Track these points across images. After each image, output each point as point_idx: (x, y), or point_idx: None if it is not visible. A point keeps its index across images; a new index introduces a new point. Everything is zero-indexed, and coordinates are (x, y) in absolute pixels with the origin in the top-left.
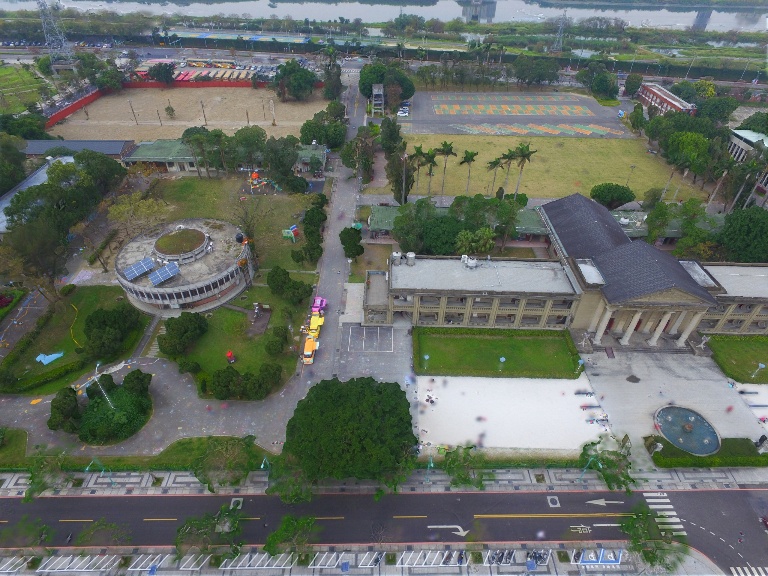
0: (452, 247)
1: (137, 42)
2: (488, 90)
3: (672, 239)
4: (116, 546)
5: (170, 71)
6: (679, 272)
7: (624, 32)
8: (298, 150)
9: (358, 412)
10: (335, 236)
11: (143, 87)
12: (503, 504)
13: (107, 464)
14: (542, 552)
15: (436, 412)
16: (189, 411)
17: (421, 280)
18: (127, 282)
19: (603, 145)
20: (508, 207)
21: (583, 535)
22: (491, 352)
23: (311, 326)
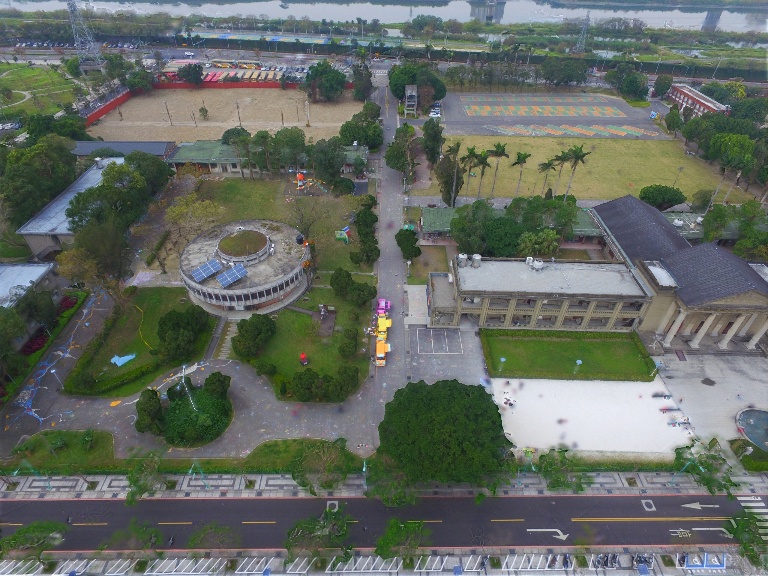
0: (515, 249)
1: (163, 43)
2: (516, 91)
3: (726, 241)
4: (219, 549)
5: (199, 72)
6: (752, 274)
7: (643, 33)
8: (343, 151)
9: (452, 415)
10: (387, 237)
11: (172, 88)
12: (599, 507)
13: (197, 466)
14: (646, 556)
15: (516, 415)
16: (270, 413)
17: (489, 282)
18: (195, 284)
19: (640, 146)
20: (568, 209)
21: (684, 539)
22: (562, 354)
23: (380, 328)
